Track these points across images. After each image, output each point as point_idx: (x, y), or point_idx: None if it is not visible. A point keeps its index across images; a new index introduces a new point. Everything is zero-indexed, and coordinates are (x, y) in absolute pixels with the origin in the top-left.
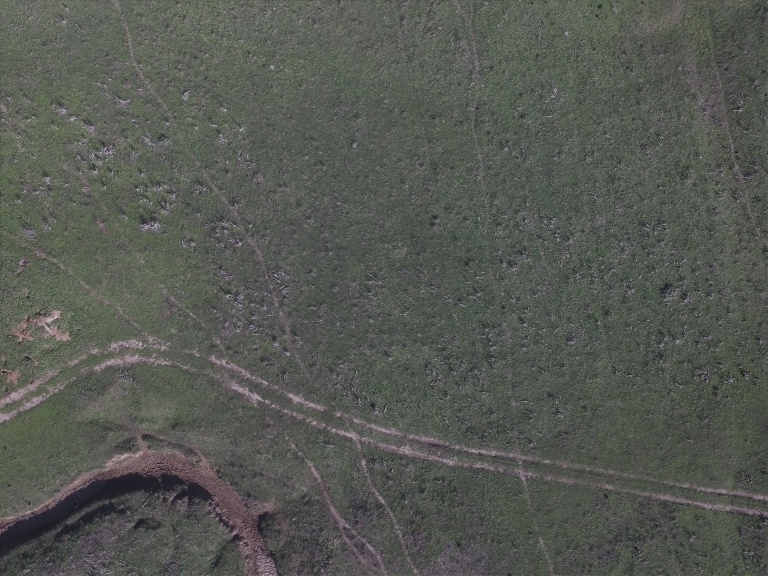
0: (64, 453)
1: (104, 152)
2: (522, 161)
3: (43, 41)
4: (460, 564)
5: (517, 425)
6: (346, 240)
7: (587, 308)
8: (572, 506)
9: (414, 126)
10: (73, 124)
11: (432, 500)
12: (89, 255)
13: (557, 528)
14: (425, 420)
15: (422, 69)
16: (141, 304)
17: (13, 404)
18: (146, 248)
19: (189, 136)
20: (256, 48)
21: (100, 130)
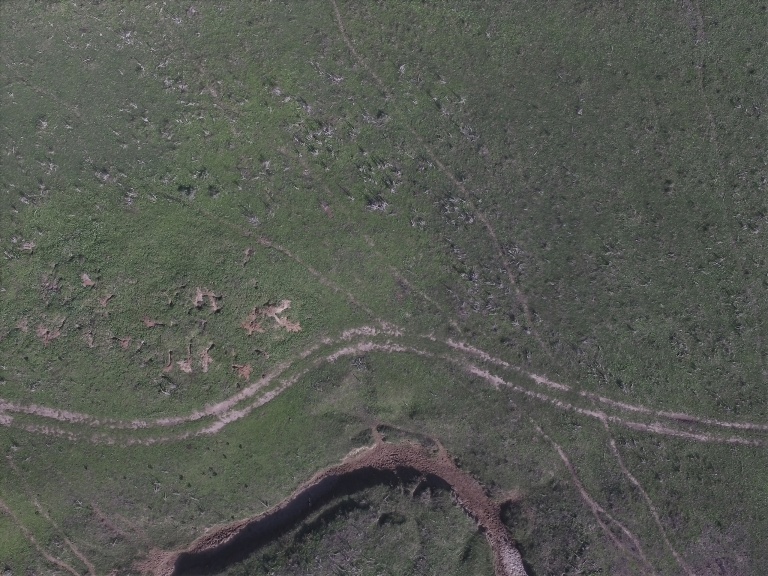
0: (301, 449)
1: (323, 132)
2: (755, 119)
3: (249, 21)
4: (721, 544)
5: None
6: (579, 211)
7: None
8: None
9: (640, 88)
10: (287, 105)
11: (687, 478)
12: (316, 240)
13: None
14: (674, 394)
15: (644, 29)
16: (373, 289)
17: (246, 400)
18: (375, 230)
19: (409, 111)
20: (470, 16)
21: (316, 110)
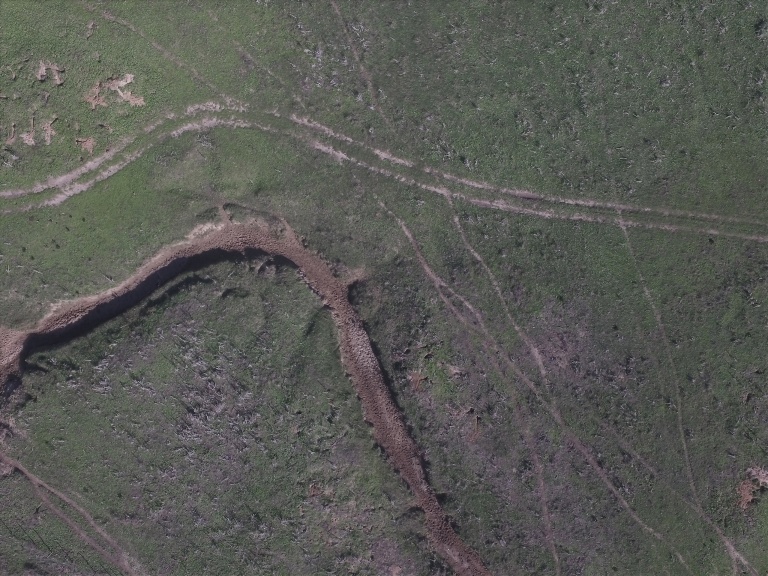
0: (145, 223)
1: None
2: None
3: None
4: (563, 319)
5: (614, 173)
6: None
7: (680, 49)
8: (677, 253)
9: None
10: None
11: (530, 254)
12: (160, 15)
13: (662, 276)
14: (518, 172)
15: None
16: (216, 64)
17: (89, 174)
18: (219, 5)
19: None
20: None
21: None
